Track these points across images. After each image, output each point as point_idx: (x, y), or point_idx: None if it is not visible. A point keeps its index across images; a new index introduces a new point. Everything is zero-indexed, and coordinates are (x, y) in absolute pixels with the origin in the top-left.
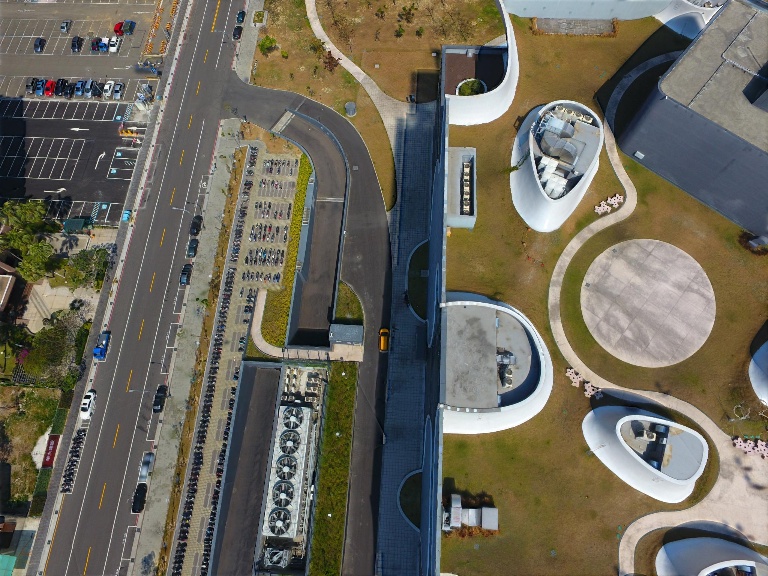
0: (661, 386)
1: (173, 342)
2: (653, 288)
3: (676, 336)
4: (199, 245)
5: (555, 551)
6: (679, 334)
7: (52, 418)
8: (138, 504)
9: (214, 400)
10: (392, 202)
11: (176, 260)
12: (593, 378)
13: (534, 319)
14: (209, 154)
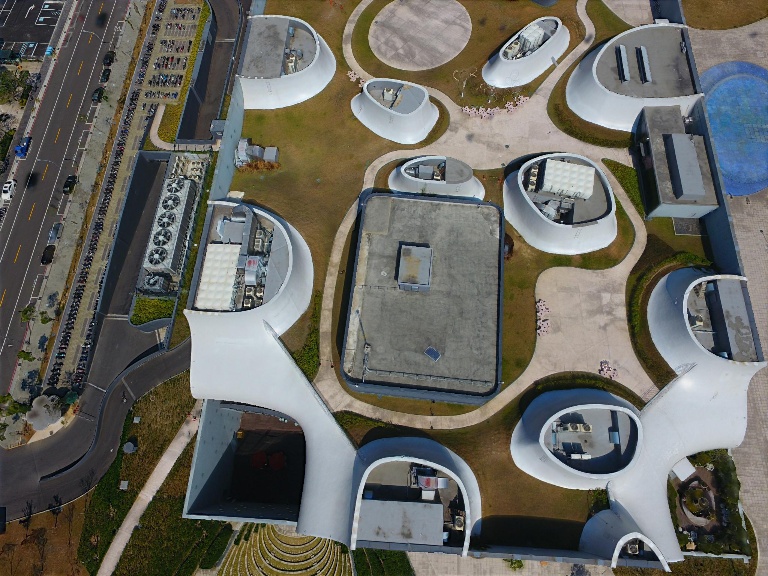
0: (418, 81)
1: (84, 144)
2: (426, 23)
3: (437, 52)
4: (111, 73)
5: (320, 179)
6: (439, 50)
7: None
8: (46, 257)
9: (116, 185)
10: None
11: (91, 84)
12: (368, 77)
13: (328, 39)
14: (125, 6)
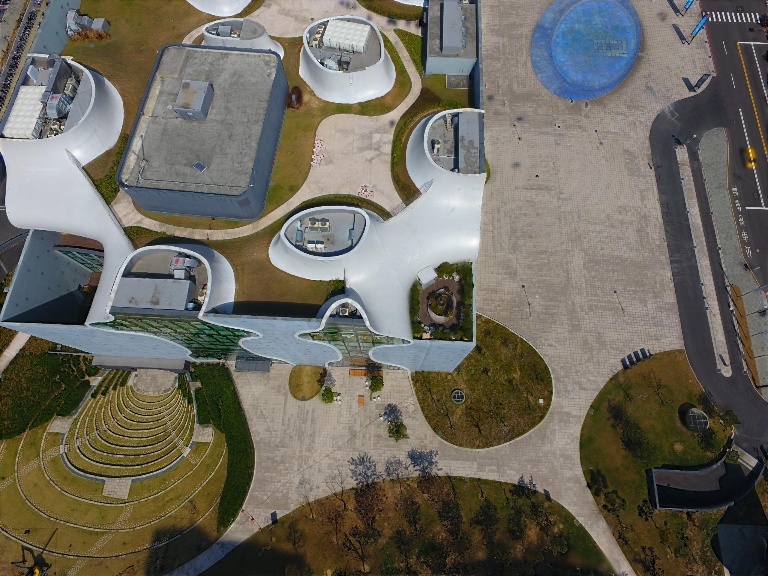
0: None
1: None
2: None
3: None
4: None
5: (143, 47)
6: None
7: None
8: None
9: (8, 94)
10: None
11: None
12: None
13: None
14: None
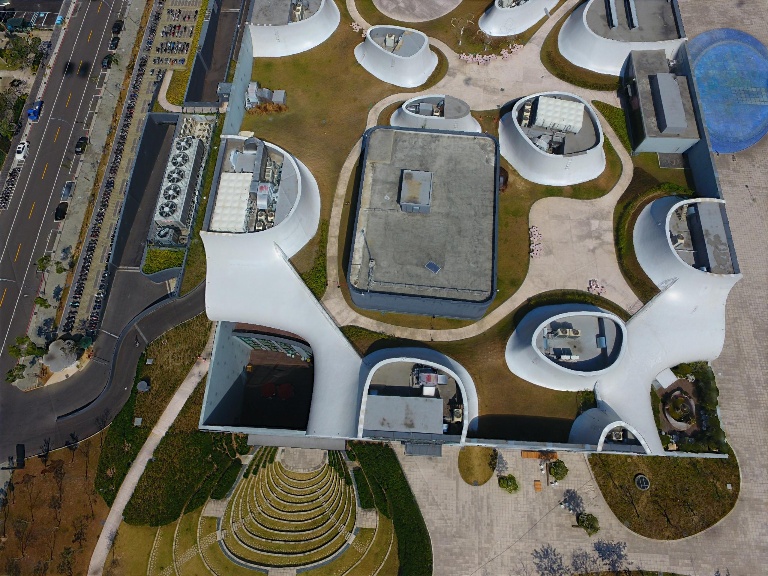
0: None
1: (94, 108)
2: None
3: (436, 5)
4: (120, 41)
5: (325, 120)
6: (438, 4)
7: None
8: (59, 213)
9: (126, 146)
10: None
11: (100, 52)
12: None
13: None
14: None
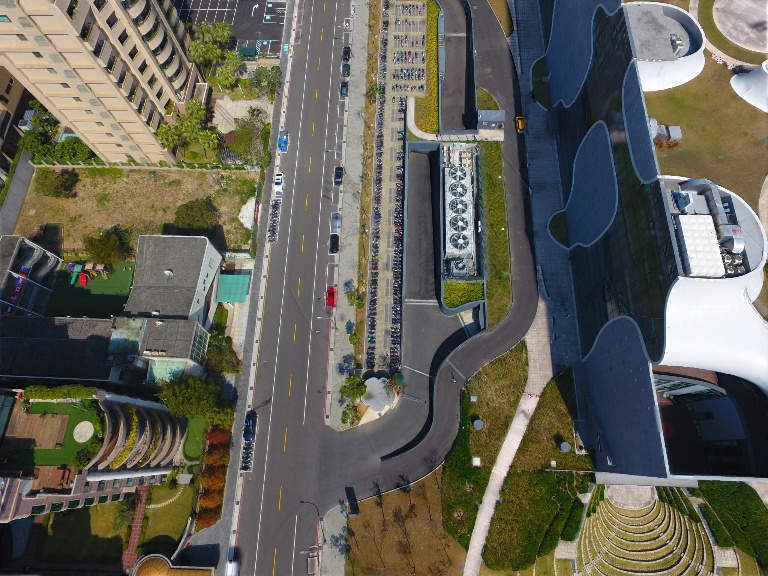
0: None
1: (341, 137)
2: (766, 8)
3: None
4: (351, 68)
5: (721, 156)
6: None
7: (251, 192)
8: (335, 245)
9: (383, 175)
10: (510, 31)
11: (333, 79)
12: (731, 60)
13: None
14: (347, 3)
